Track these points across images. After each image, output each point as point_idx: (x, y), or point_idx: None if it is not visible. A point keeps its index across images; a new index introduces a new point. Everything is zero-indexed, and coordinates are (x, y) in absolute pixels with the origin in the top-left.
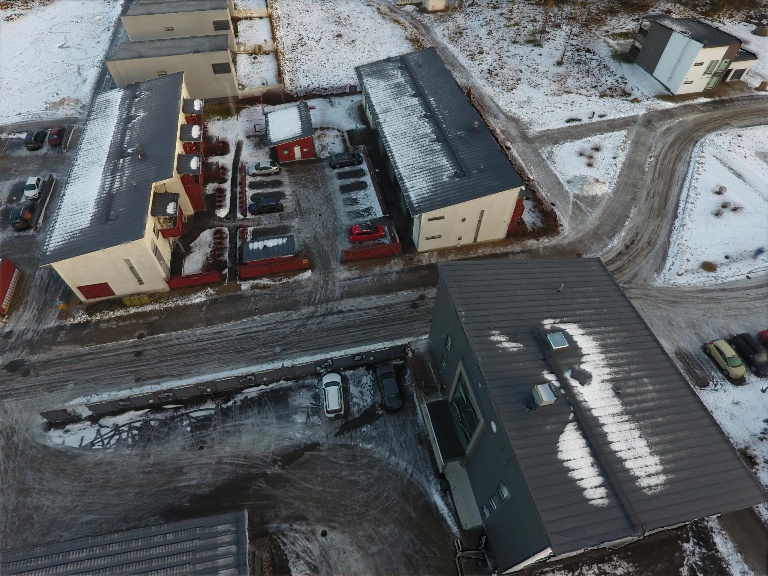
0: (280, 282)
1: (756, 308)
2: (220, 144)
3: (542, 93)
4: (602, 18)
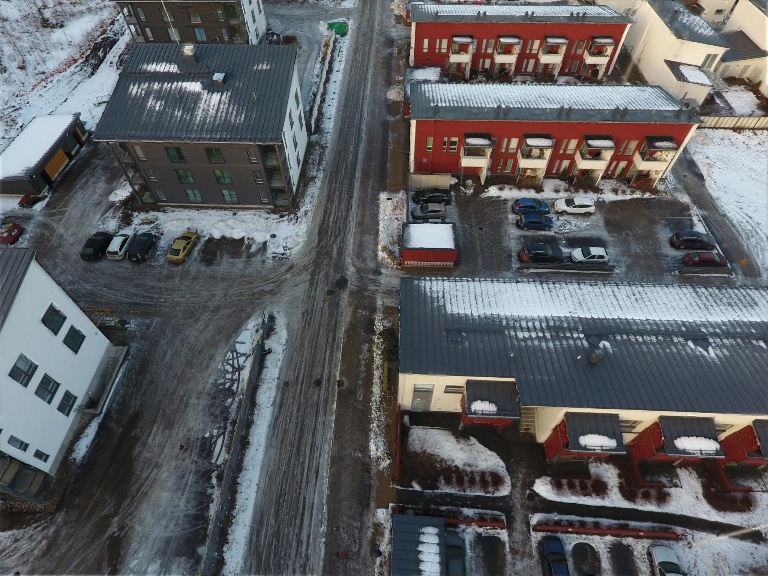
0: (377, 574)
1: None
2: (739, 493)
3: None
4: None
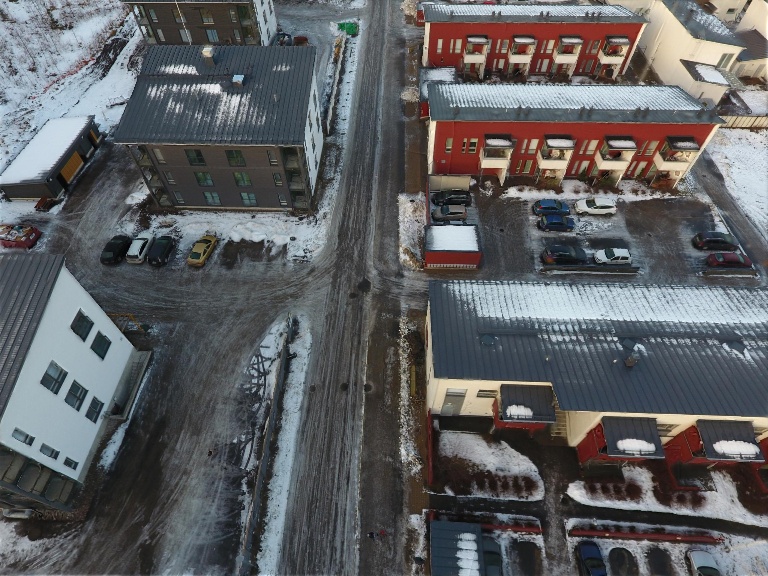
0: None
1: None
2: None
3: None
4: None
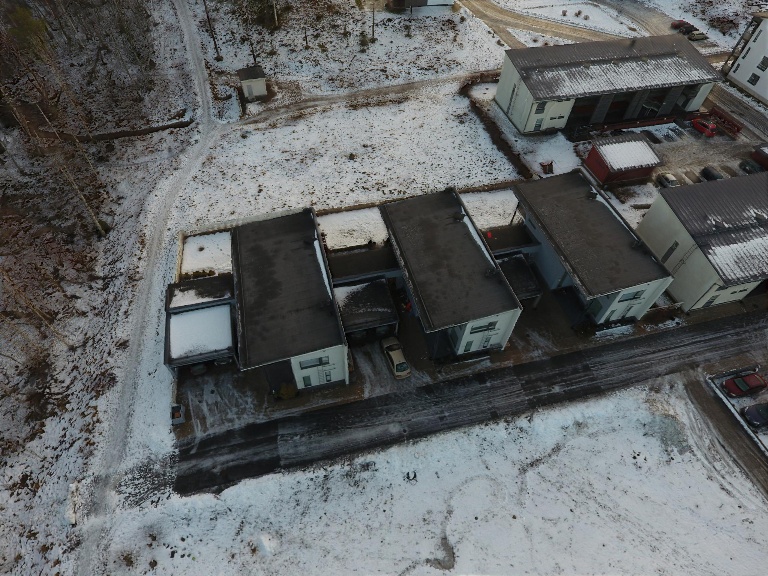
0: None
1: (654, 25)
2: None
3: (460, 50)
4: (326, 4)
